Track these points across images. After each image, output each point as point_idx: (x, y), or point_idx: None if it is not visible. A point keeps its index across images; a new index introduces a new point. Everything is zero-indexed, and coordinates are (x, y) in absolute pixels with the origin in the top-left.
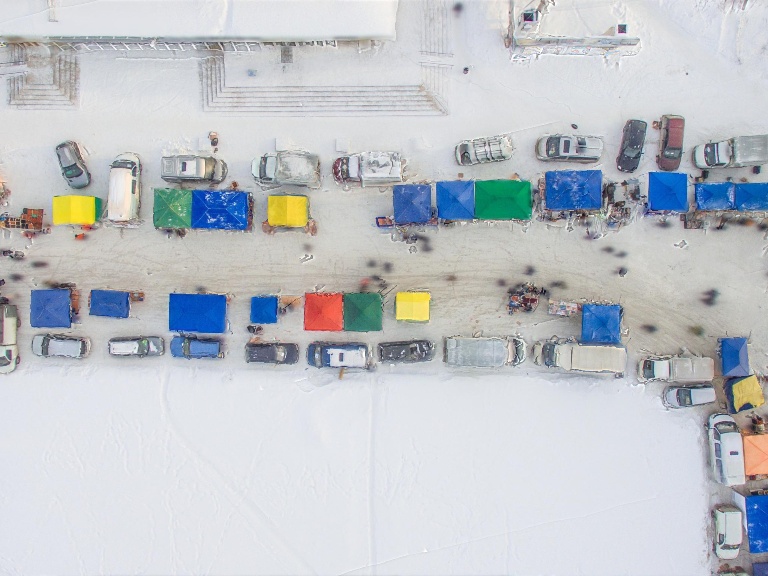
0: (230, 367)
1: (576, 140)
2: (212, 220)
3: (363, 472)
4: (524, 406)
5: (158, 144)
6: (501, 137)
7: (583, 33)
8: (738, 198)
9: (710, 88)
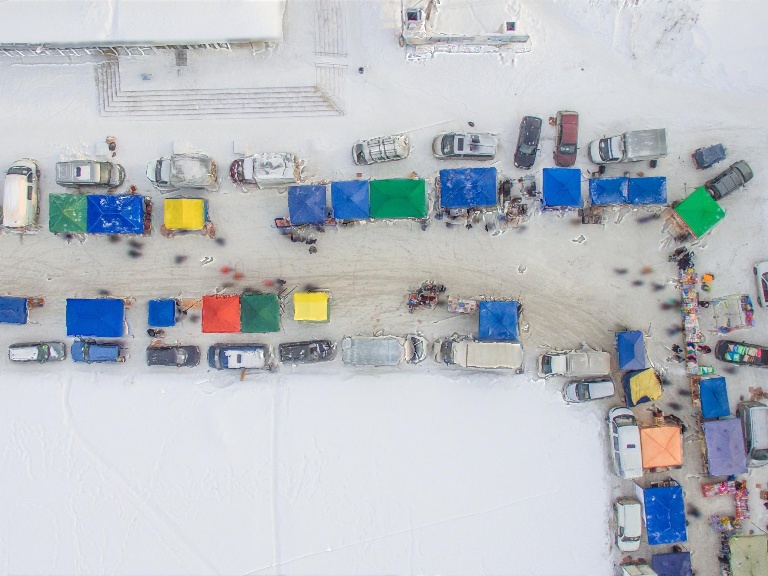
0: (132, 371)
1: (470, 138)
2: (107, 225)
3: (266, 472)
4: (427, 403)
5: (56, 150)
6: (397, 136)
7: (478, 31)
8: (631, 192)
9: (606, 83)
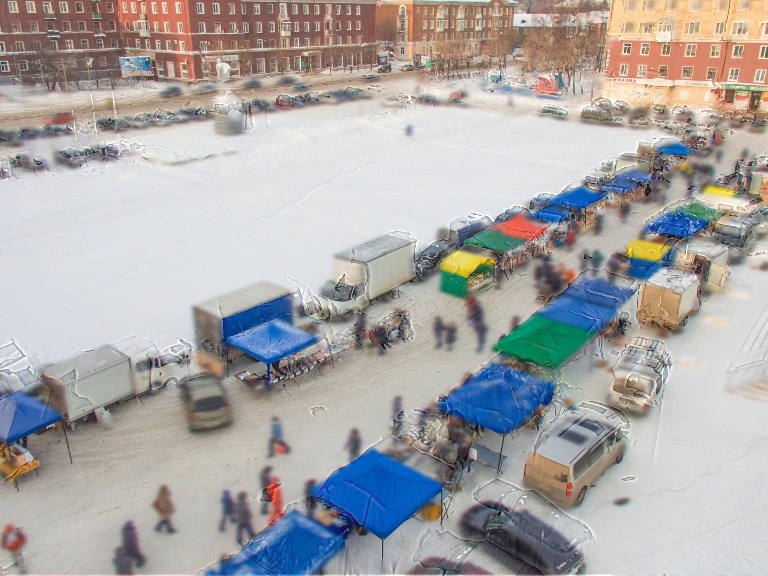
0: None
1: (599, 420)
2: None
3: None
4: None
5: None
6: None
7: None
8: (251, 561)
9: None
